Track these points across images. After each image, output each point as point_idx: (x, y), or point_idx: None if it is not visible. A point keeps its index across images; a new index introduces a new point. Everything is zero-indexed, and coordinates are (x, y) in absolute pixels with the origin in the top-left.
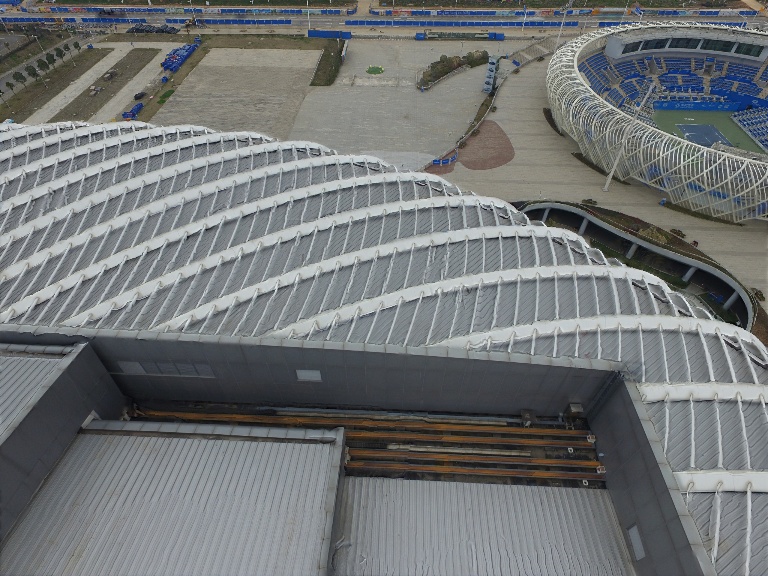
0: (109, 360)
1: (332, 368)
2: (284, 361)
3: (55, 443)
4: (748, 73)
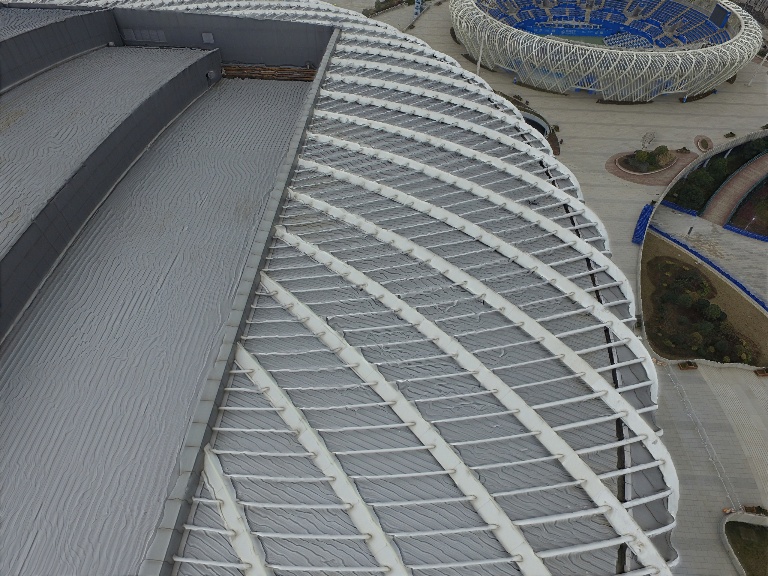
0: (120, 25)
1: (216, 30)
2: (195, 25)
3: (99, 37)
4: (619, 6)
